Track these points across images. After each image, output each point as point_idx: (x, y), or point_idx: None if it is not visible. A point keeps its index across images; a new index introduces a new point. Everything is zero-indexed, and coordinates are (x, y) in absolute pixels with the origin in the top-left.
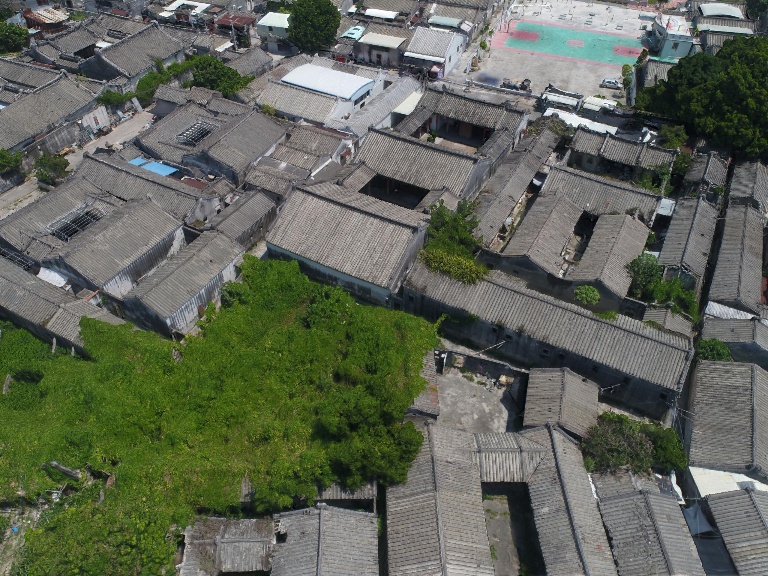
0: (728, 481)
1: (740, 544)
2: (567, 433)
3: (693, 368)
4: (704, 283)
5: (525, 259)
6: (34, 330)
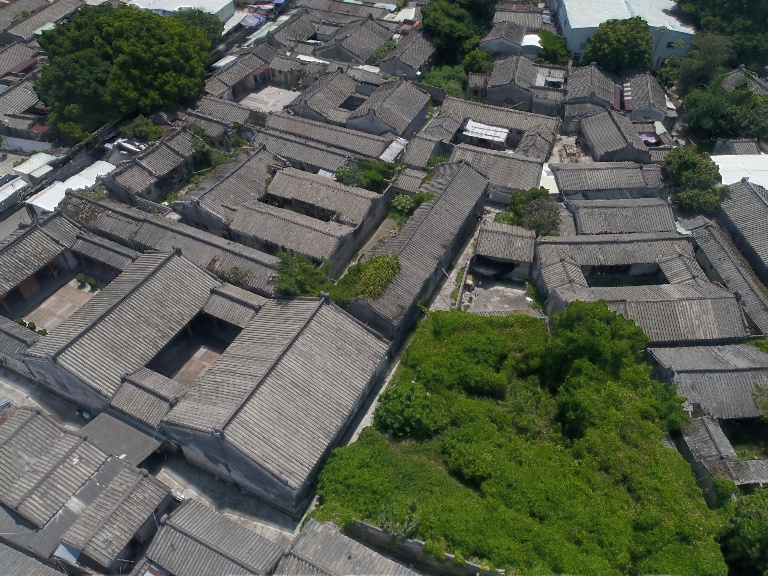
0: (547, 179)
1: (589, 183)
2: None
3: None
4: None
5: (340, 241)
6: None
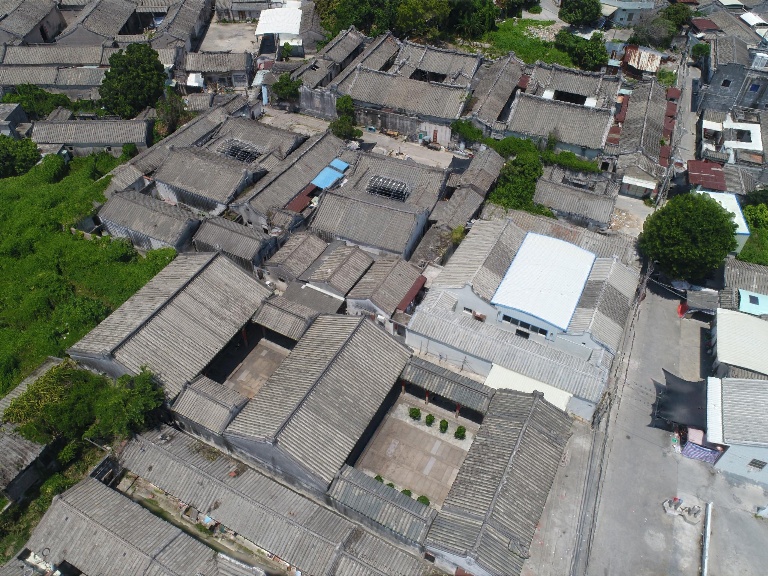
0: None
1: None
2: None
3: None
4: None
5: None
6: None
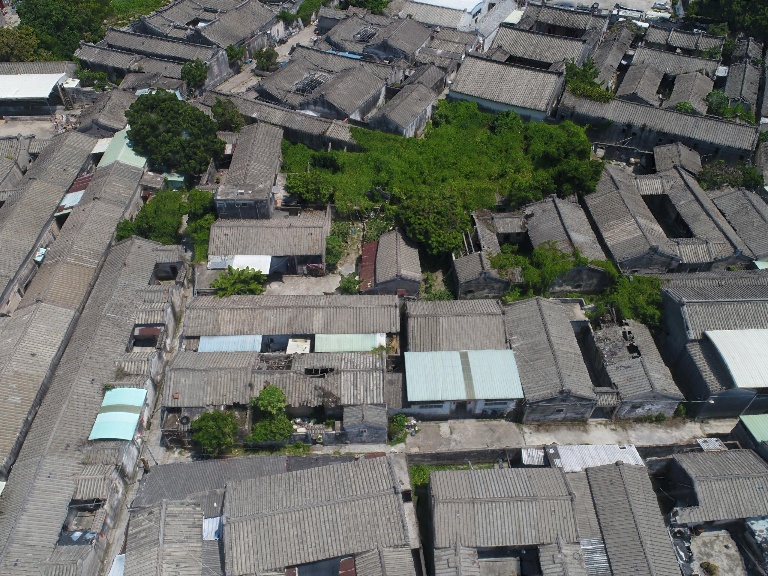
0: None
1: None
2: (686, 171)
3: (756, 151)
4: (756, 110)
5: (633, 96)
6: (309, 143)
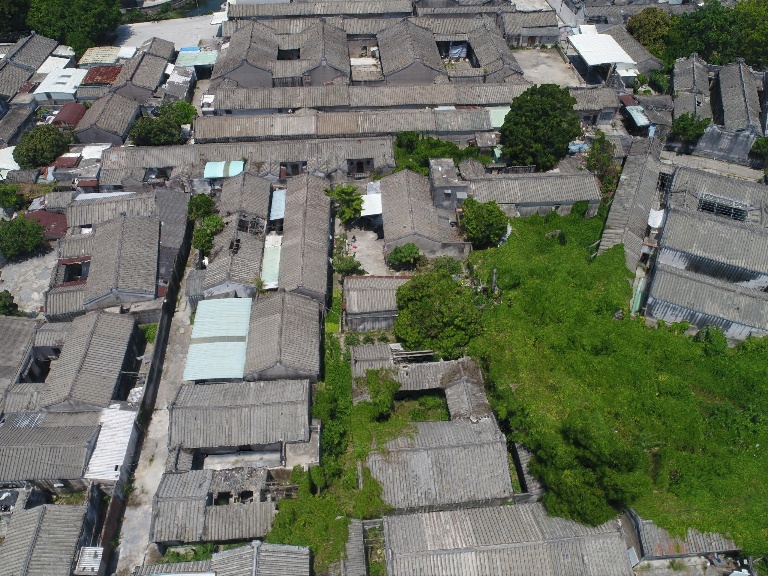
0: None
1: None
2: None
3: None
4: None
5: None
6: None
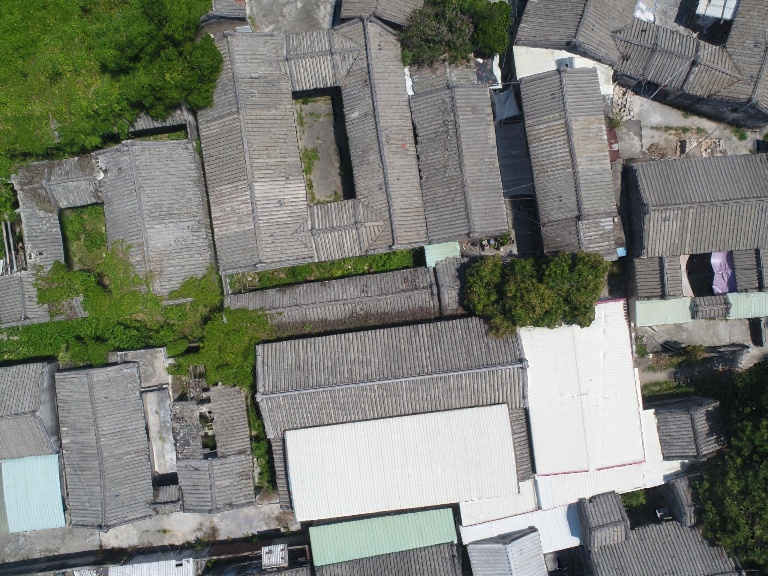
0: (547, 59)
1: (538, 127)
2: (385, 23)
3: None
4: None
5: None
6: None
